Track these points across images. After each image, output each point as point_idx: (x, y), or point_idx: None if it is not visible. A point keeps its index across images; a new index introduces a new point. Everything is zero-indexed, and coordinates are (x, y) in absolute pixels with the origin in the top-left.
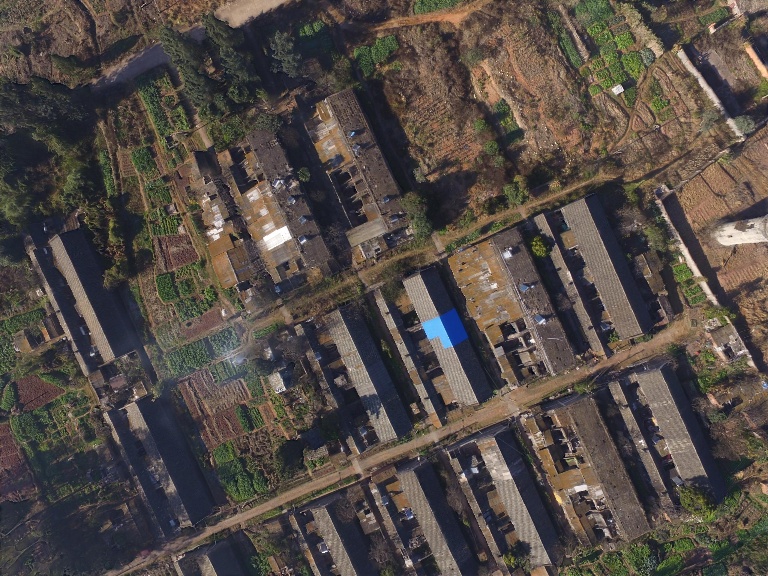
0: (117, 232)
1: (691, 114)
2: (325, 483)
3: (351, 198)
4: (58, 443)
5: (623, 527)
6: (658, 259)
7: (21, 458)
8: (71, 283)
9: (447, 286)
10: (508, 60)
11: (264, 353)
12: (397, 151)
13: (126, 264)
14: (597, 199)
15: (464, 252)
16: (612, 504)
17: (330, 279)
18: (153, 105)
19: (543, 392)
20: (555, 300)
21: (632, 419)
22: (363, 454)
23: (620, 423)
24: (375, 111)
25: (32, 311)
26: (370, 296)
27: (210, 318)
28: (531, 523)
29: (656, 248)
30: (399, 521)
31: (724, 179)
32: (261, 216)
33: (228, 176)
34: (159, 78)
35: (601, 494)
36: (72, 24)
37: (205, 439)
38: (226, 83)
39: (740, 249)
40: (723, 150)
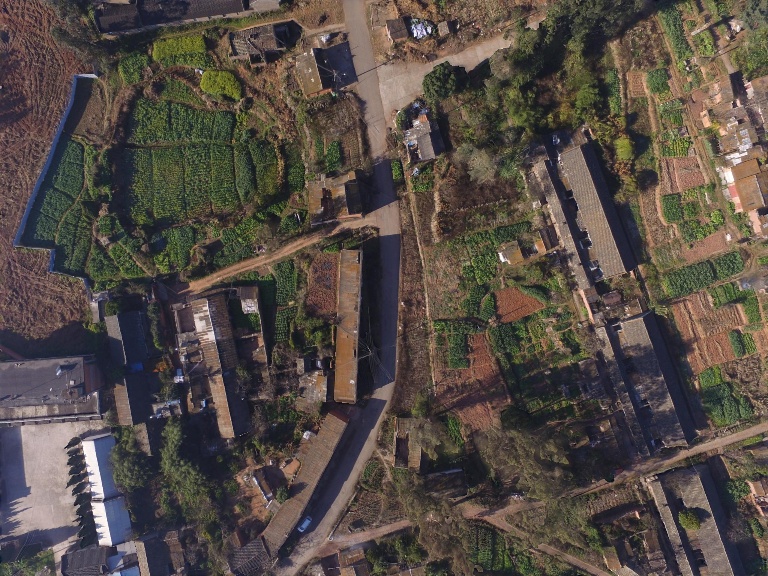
0: (634, 149)
1: None
2: None
3: None
4: (532, 357)
5: None
6: None
7: (495, 369)
8: (581, 196)
9: None
10: None
11: None
12: None
13: None
14: None
15: None
16: None
17: None
18: (675, 28)
19: None
20: None
21: None
22: None
23: None
24: None
25: (519, 223)
26: None
27: (713, 242)
28: None
29: None
30: None
31: None
32: None
33: (761, 101)
34: (682, 2)
35: None
36: None
37: (692, 362)
38: None
39: None
40: None
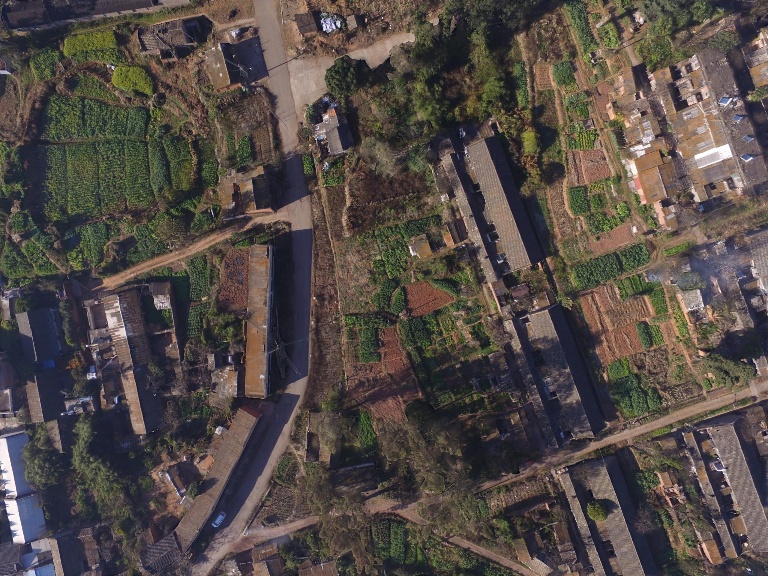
0: (539, 141)
1: None
2: (719, 404)
3: None
4: (443, 350)
5: None
6: None
7: (406, 363)
8: (487, 189)
9: None
10: None
11: (681, 270)
12: None
13: None
14: None
15: None
16: None
17: None
18: (580, 20)
19: None
20: None
21: None
22: (761, 377)
23: None
24: None
25: (429, 217)
26: None
27: (620, 234)
28: None
29: None
30: None
31: None
32: (697, 134)
33: (663, 93)
34: None
35: None
36: None
37: (601, 354)
38: None
39: None
40: None
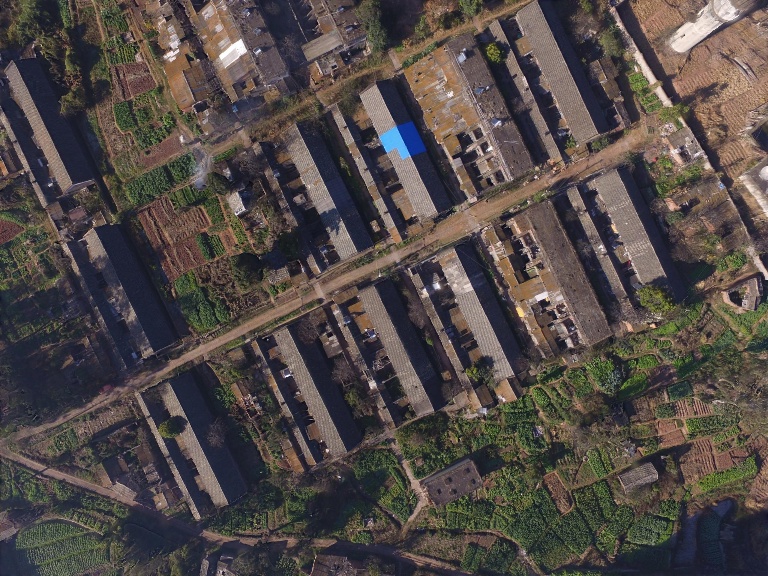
0: (73, 58)
1: None
2: (288, 310)
3: (307, 16)
4: (18, 282)
5: (584, 331)
6: (613, 65)
7: None
8: (28, 112)
9: (404, 100)
10: None
11: (223, 175)
12: None
13: (83, 93)
14: (551, 4)
15: (420, 61)
16: (572, 308)
17: (288, 99)
18: None
19: (503, 206)
20: (511, 104)
21: (591, 224)
22: (325, 278)
23: (580, 234)
24: None
25: None
26: (328, 116)
27: (169, 145)
28: (493, 334)
29: (611, 53)
30: (362, 343)
31: None
32: (216, 33)
33: None
34: None
35: (561, 299)
36: None
37: (166, 270)
38: None
39: (695, 56)
40: None
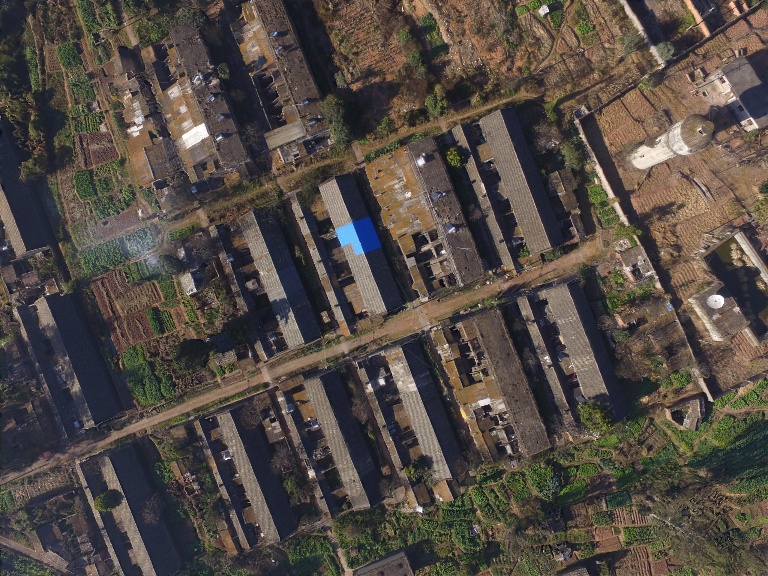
0: (37, 125)
1: (615, 40)
2: (233, 391)
3: (273, 102)
4: None
5: (523, 442)
6: (573, 178)
7: None
8: None
9: (364, 195)
10: None
11: (177, 253)
12: (322, 58)
13: (45, 159)
14: (514, 113)
15: (380, 159)
16: (513, 418)
17: (248, 183)
18: (82, 0)
19: (454, 307)
20: (467, 211)
21: (538, 335)
22: (273, 362)
23: (529, 341)
24: (302, 18)
25: None
26: (288, 203)
27: (127, 218)
28: (434, 436)
29: (571, 166)
30: (304, 431)
31: (644, 105)
32: (180, 113)
33: (150, 72)
34: None
35: (503, 408)
36: None
37: (115, 341)
38: None
39: (655, 174)
40: (643, 76)
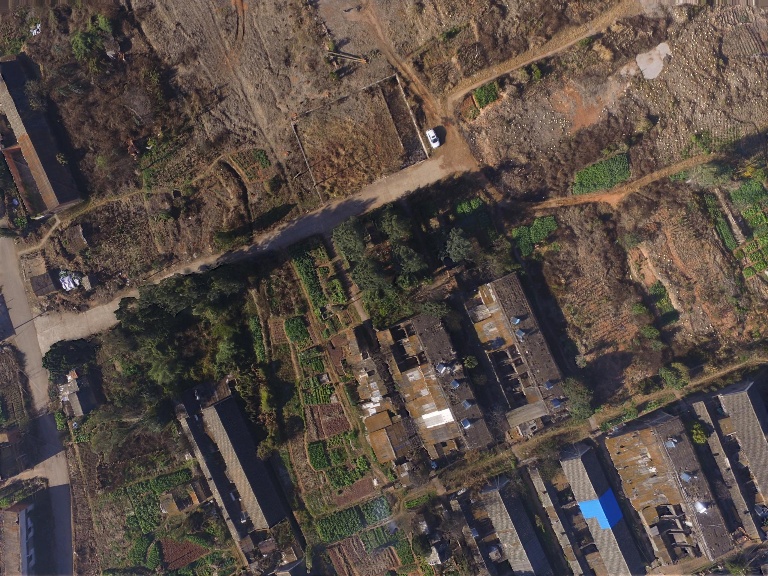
0: (272, 403)
1: None
2: None
3: (508, 376)
4: None
5: None
6: None
7: None
8: (224, 452)
9: (602, 465)
10: (666, 243)
11: (418, 526)
12: (554, 330)
13: None
14: (756, 388)
15: (623, 436)
16: None
17: (484, 453)
18: (308, 276)
19: (692, 567)
20: (714, 487)
21: None
22: None
23: None
24: (532, 290)
25: (178, 472)
26: (523, 470)
27: (361, 487)
28: None
29: None
30: None
31: None
32: (421, 396)
33: (387, 354)
34: (314, 249)
35: None
36: (223, 190)
37: None
38: (390, 266)
39: None
40: None
